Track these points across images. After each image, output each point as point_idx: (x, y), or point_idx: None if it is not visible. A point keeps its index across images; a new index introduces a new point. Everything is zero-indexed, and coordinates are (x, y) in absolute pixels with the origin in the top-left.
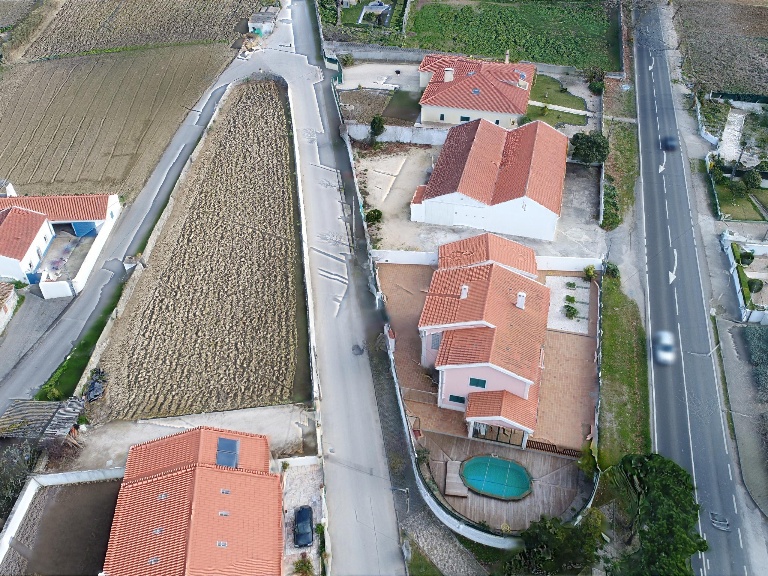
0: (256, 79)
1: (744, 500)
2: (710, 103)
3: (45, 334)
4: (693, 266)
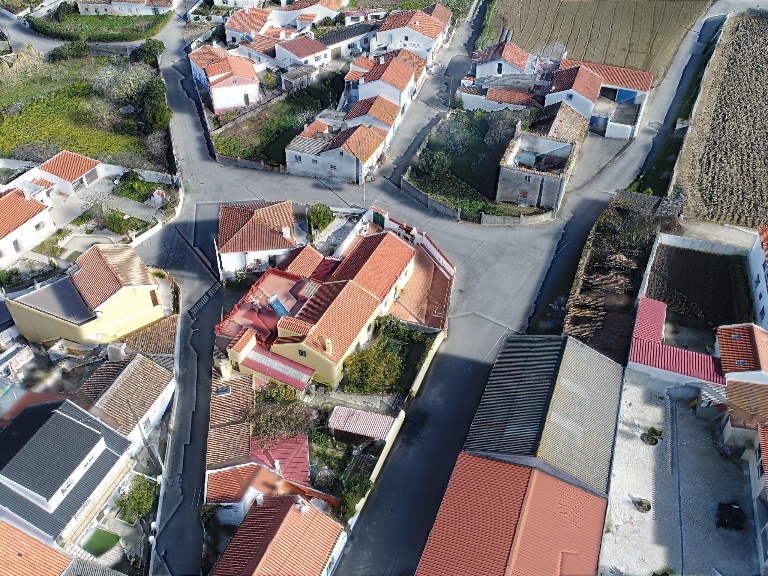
0: (750, 15)
1: None
2: None
3: (615, 158)
4: None
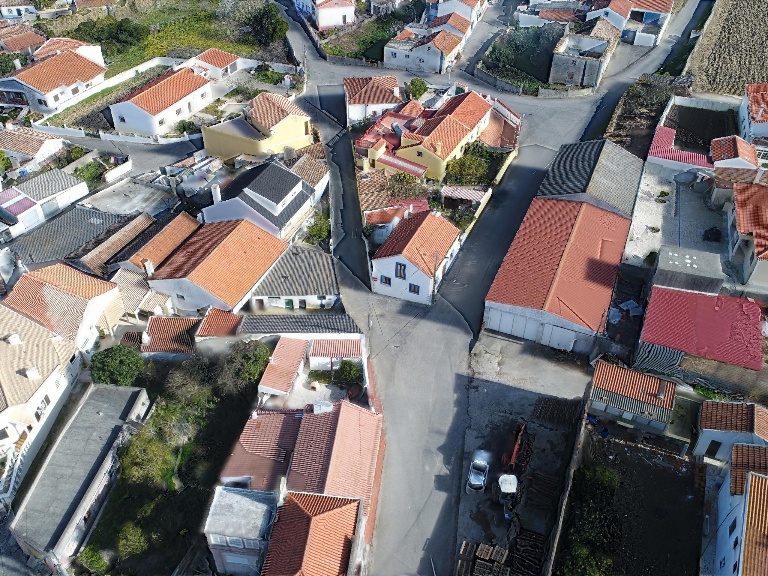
0: None
1: None
2: None
3: (642, 58)
4: None
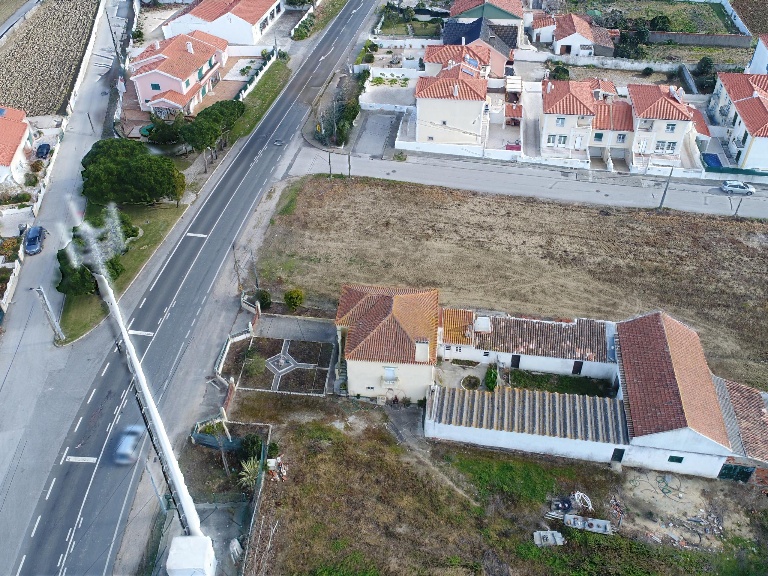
0: None
1: (298, 135)
2: None
3: None
4: (340, 53)
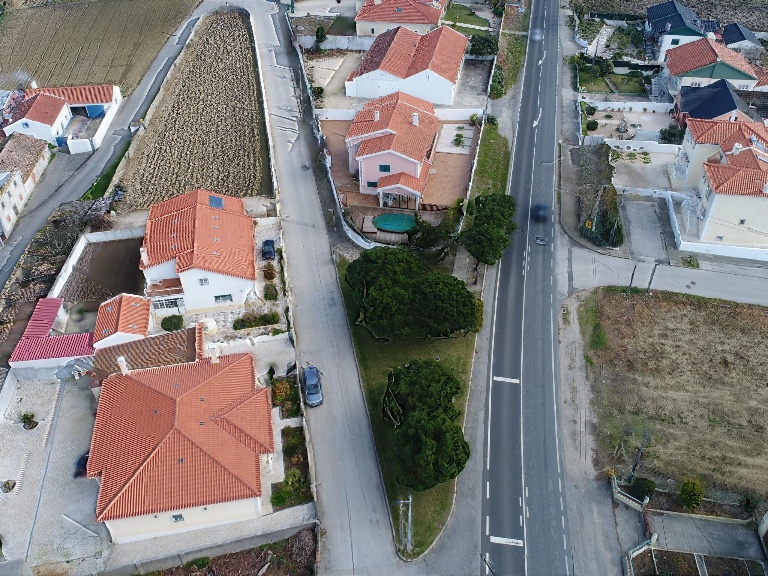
0: (223, 11)
1: (559, 231)
2: (589, 22)
3: (75, 173)
4: (552, 117)
